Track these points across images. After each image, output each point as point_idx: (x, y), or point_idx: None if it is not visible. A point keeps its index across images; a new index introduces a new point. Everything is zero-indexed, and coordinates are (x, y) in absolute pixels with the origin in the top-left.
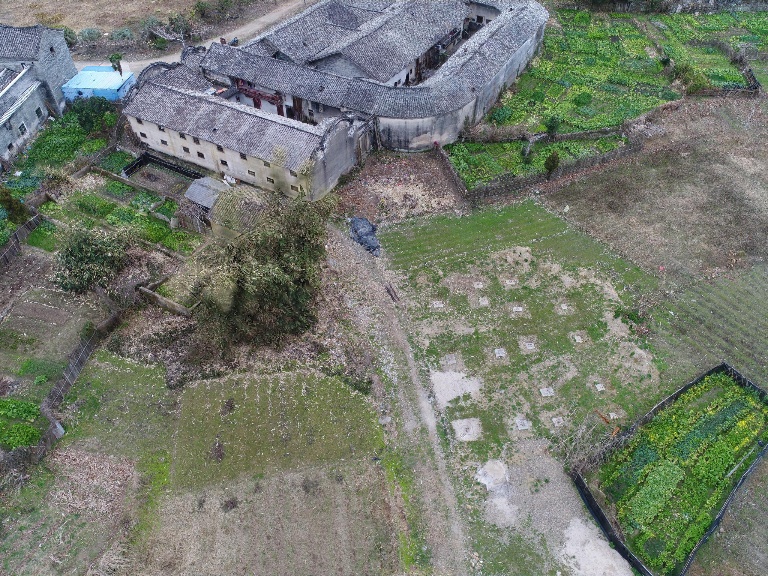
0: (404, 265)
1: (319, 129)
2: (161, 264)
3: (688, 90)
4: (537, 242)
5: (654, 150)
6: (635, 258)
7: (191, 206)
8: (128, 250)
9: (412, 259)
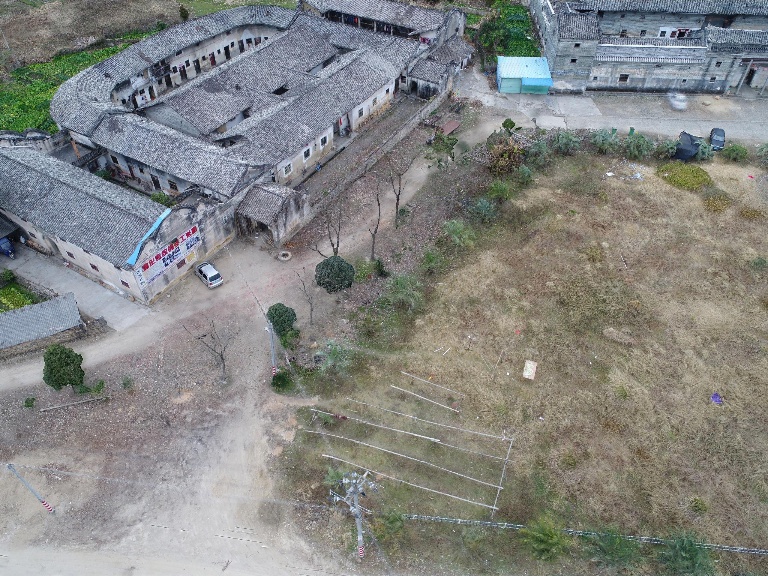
0: (290, 2)
1: (327, 2)
2: (409, 0)
3: (7, 65)
4: (218, 8)
5: (96, 38)
6: (174, 2)
7: (400, 2)
8: (430, 6)
9: (286, 4)
